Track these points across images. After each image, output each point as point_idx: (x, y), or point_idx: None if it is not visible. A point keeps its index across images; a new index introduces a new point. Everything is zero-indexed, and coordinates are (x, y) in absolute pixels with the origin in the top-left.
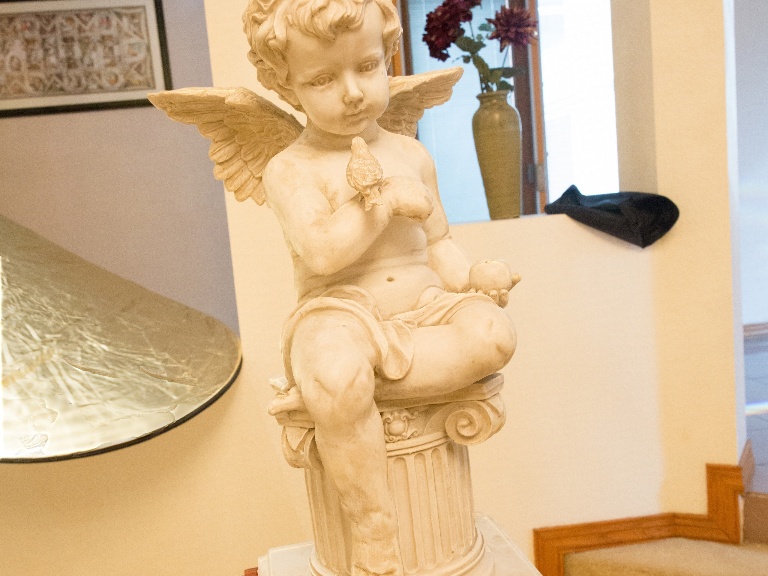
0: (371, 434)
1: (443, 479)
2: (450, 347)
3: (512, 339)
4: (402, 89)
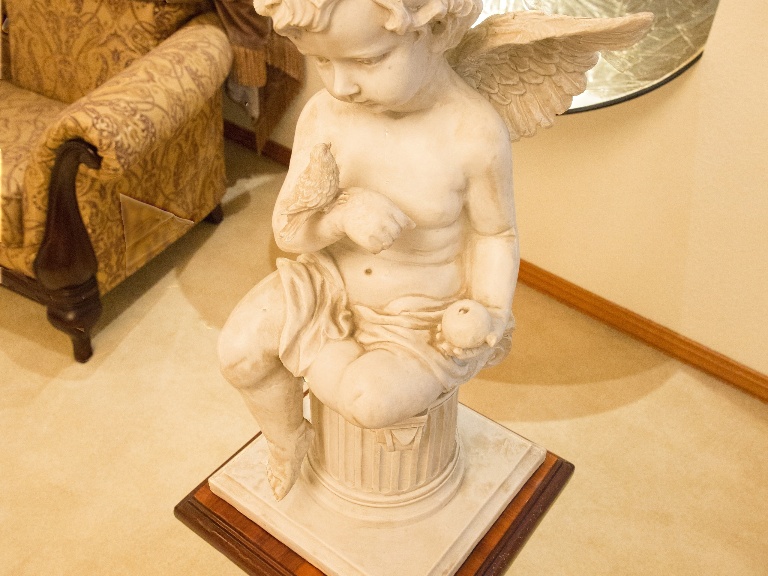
0: (261, 399)
1: (372, 443)
2: (330, 385)
3: (372, 420)
4: (511, 41)
